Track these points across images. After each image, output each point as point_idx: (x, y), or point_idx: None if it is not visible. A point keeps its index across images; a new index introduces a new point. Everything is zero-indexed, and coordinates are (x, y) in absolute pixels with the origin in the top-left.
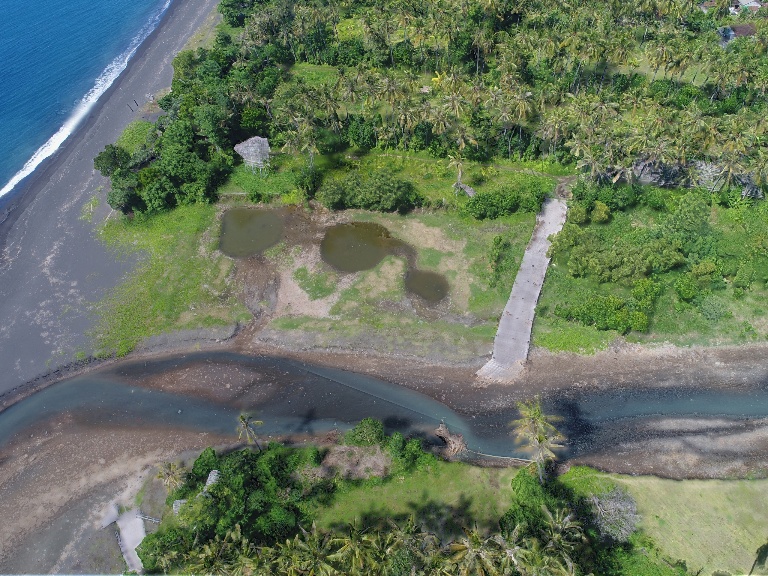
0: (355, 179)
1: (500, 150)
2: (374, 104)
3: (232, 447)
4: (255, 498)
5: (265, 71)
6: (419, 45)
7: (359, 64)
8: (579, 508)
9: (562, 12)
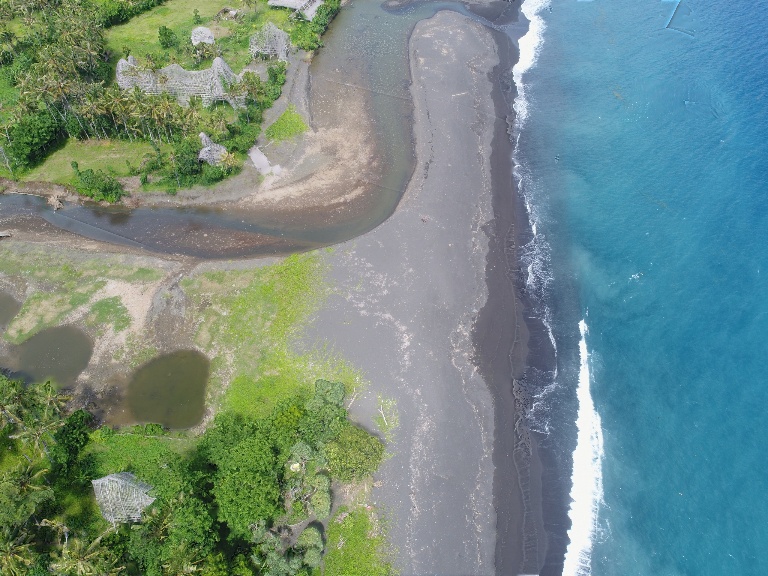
0: None
1: None
2: None
3: (203, 198)
4: None
5: None
6: None
7: None
8: (2, 161)
9: None
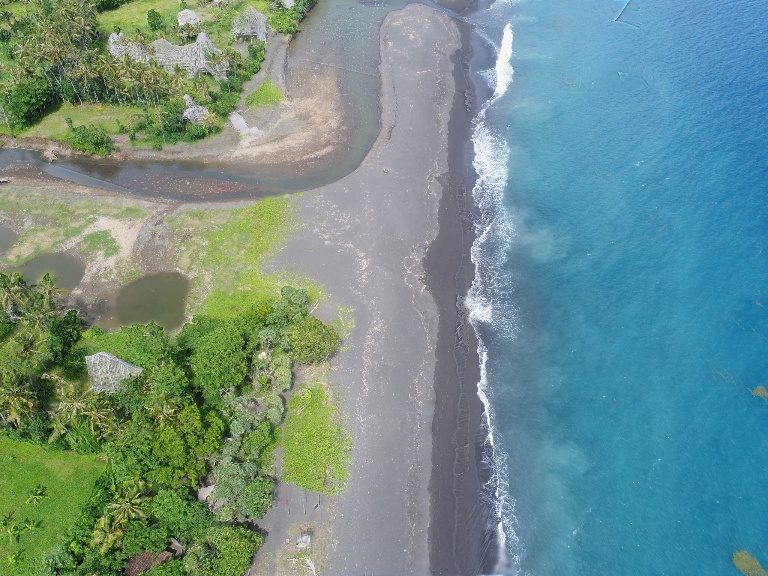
0: None
1: None
2: None
3: (186, 153)
4: None
5: None
6: None
7: None
8: (1, 120)
9: None
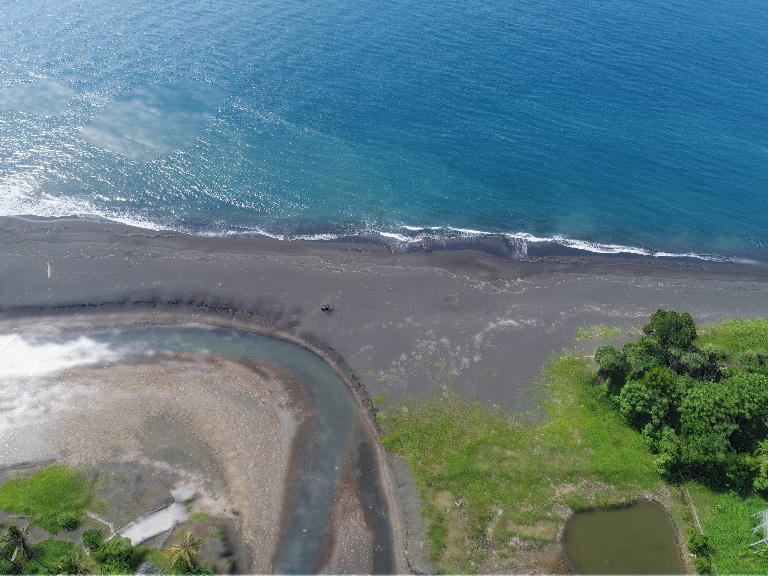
0: None
1: None
2: None
3: None
4: None
5: None
6: None
7: None
8: None
9: None
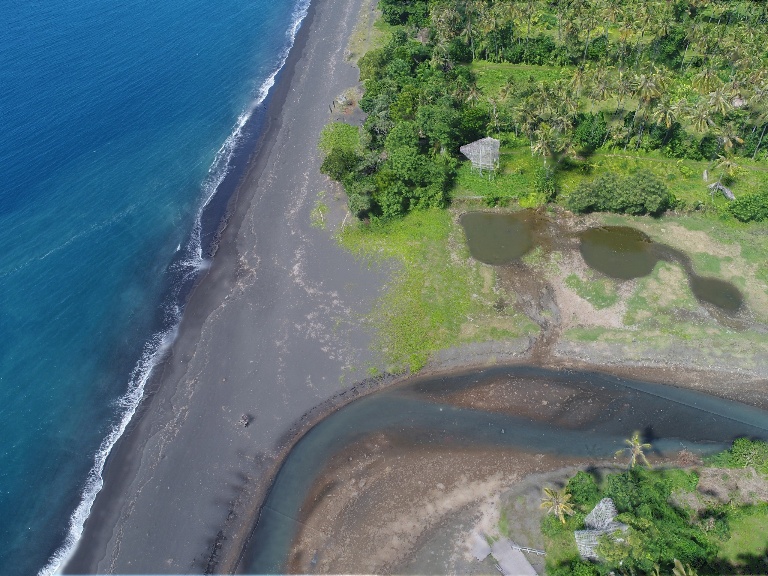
0: (612, 181)
1: (746, 149)
2: (580, 102)
3: (582, 470)
4: (670, 529)
5: (455, 70)
6: (614, 41)
7: (601, 60)
8: None
9: (757, 5)
